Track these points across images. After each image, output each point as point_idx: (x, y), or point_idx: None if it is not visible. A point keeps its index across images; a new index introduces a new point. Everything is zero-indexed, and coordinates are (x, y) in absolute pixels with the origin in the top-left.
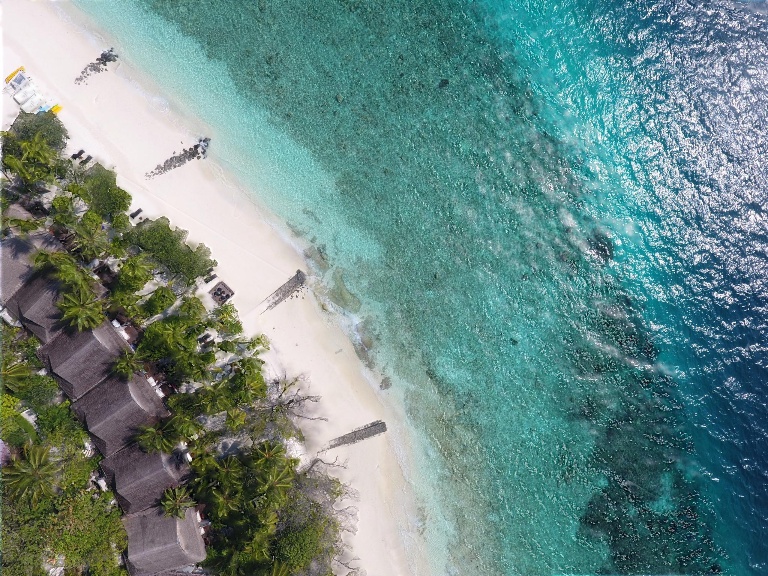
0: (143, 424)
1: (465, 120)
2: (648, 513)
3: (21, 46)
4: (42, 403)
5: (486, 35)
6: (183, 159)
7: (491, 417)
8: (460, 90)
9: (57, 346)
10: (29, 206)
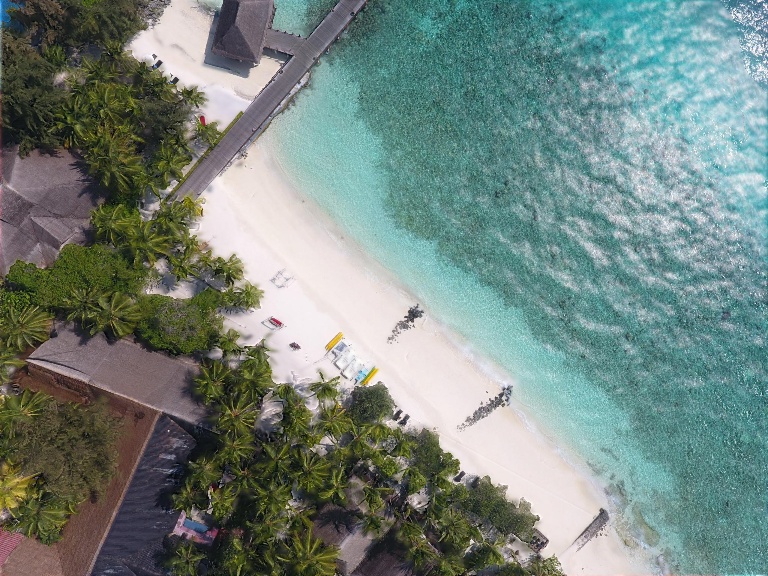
0: None
1: (747, 350)
2: None
3: (338, 312)
4: None
5: (761, 265)
6: (490, 409)
7: None
8: (741, 321)
9: None
10: (358, 472)
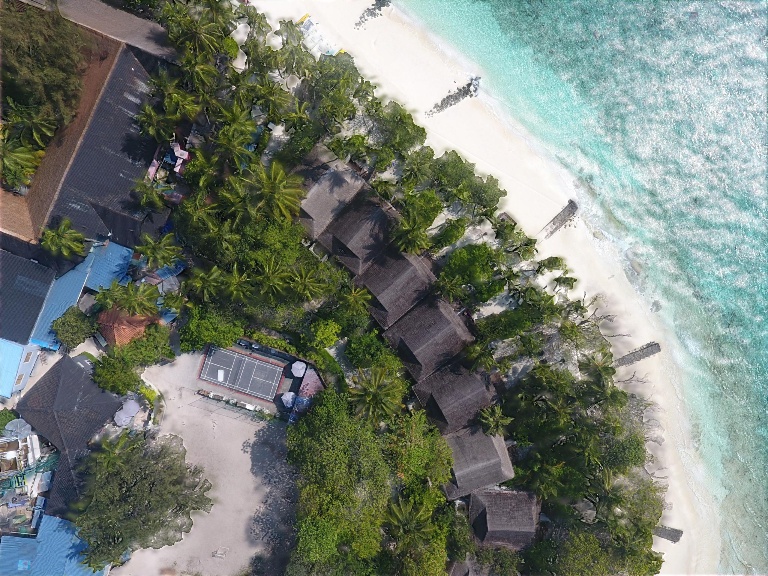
0: (454, 348)
1: (714, 51)
2: None
3: None
4: (355, 333)
5: None
6: (458, 97)
7: (754, 335)
8: (708, 22)
9: (372, 276)
10: (326, 146)
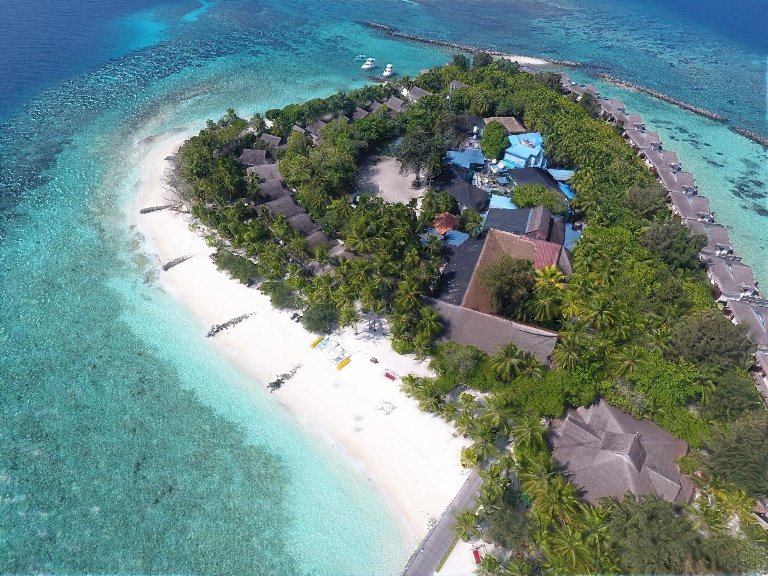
0: None
1: None
2: (6, 184)
3: (340, 385)
4: None
5: None
6: (228, 323)
7: None
8: None
9: (308, 226)
10: None
